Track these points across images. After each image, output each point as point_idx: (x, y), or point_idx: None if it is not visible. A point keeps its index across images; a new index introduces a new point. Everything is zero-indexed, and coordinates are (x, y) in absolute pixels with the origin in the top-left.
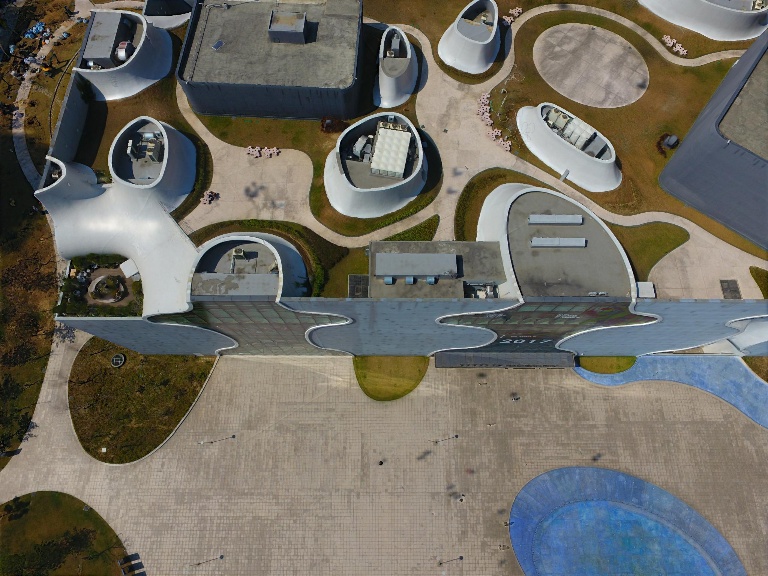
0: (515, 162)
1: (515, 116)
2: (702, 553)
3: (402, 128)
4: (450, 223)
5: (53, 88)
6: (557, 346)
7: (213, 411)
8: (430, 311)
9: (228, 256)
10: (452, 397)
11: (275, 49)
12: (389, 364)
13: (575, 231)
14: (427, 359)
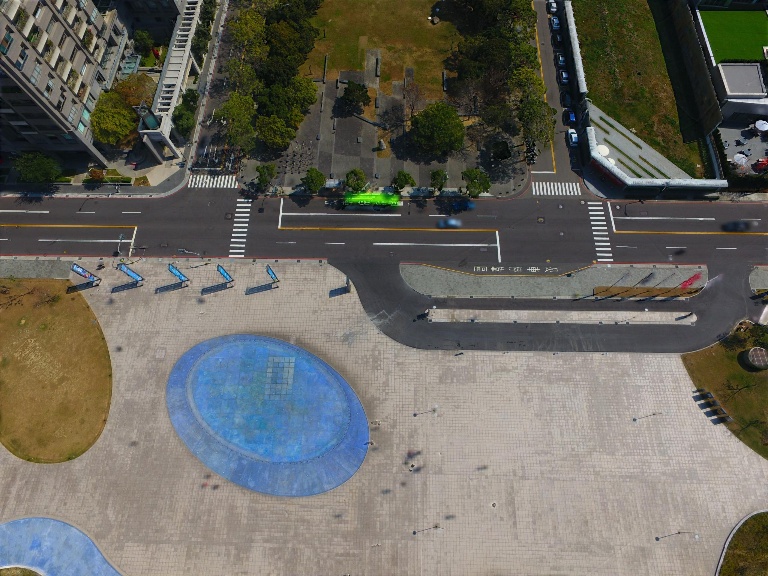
0: None
1: None
2: (198, 415)
3: None
4: None
5: None
6: None
7: (690, 571)
8: None
9: None
10: None
11: None
12: None
13: None
14: None
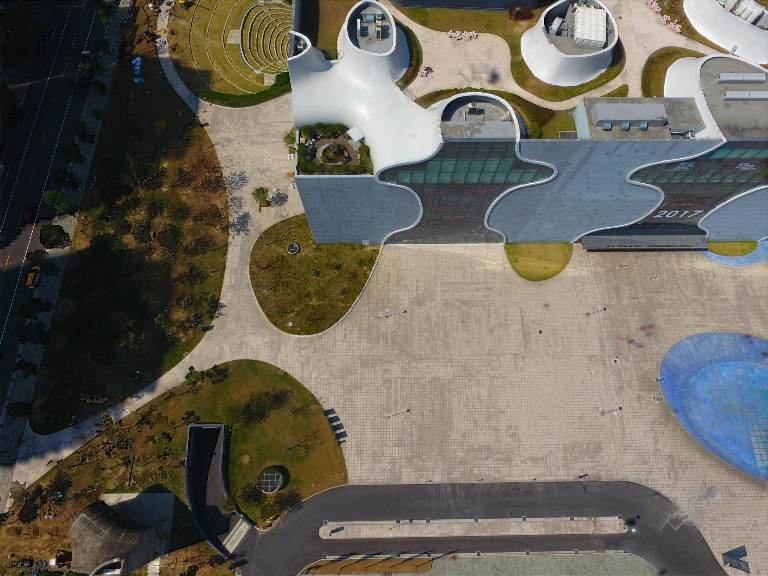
0: (686, 42)
1: (682, 4)
2: None
3: (595, 8)
4: (638, 91)
5: (189, 19)
6: (701, 222)
7: (384, 291)
8: (634, 158)
9: (459, 113)
10: (597, 277)
11: None
12: (537, 250)
13: (758, 88)
14: (571, 245)
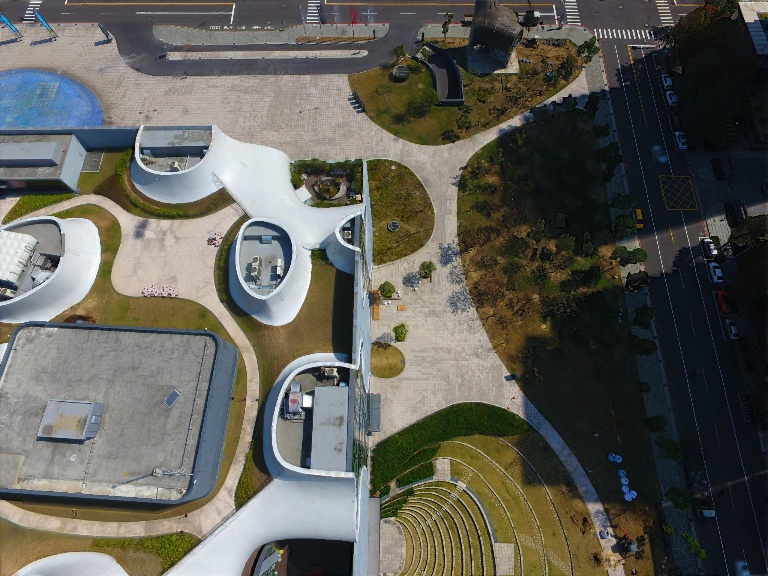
0: None
1: None
2: None
3: None
4: None
5: None
6: None
7: None
8: None
9: None
10: None
11: (101, 392)
12: None
13: None
14: None
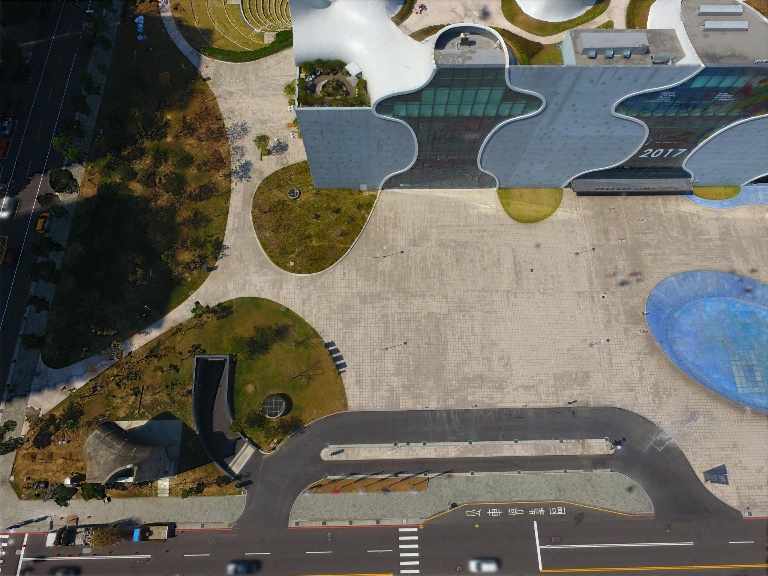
0: None
1: None
2: None
3: None
4: (623, 26)
5: None
6: (685, 162)
7: (381, 233)
8: (618, 87)
9: (452, 44)
10: (586, 219)
11: None
12: (529, 194)
13: (736, 20)
14: (561, 190)
